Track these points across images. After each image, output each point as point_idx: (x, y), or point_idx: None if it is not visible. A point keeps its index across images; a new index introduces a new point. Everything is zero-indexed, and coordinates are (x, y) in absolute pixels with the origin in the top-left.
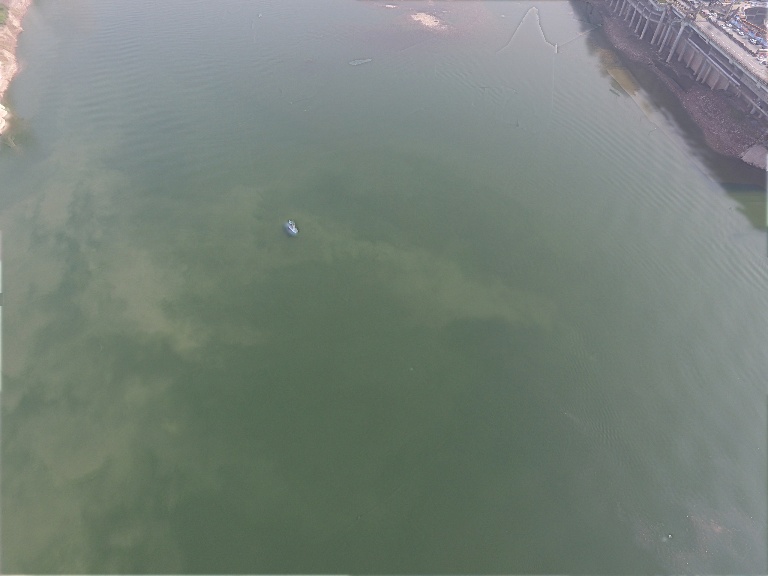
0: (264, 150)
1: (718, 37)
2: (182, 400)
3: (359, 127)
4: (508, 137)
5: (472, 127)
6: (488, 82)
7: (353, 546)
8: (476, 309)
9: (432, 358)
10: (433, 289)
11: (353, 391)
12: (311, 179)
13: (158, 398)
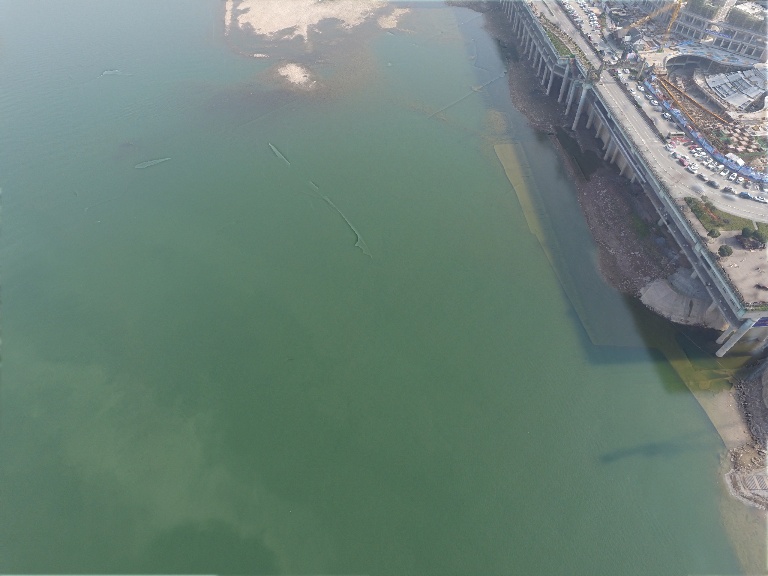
0: None
1: (623, 109)
2: None
3: (153, 249)
4: (338, 264)
5: (297, 246)
6: None
7: None
8: None
9: None
10: None
11: None
12: (22, 367)
13: None
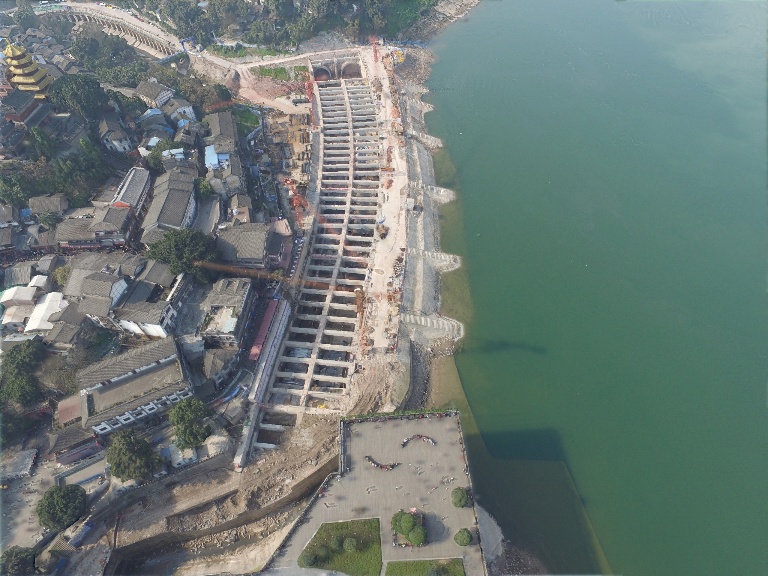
0: None
1: None
2: None
3: None
4: None
5: None
6: None
7: None
8: None
9: None
10: None
11: None
12: None
13: None
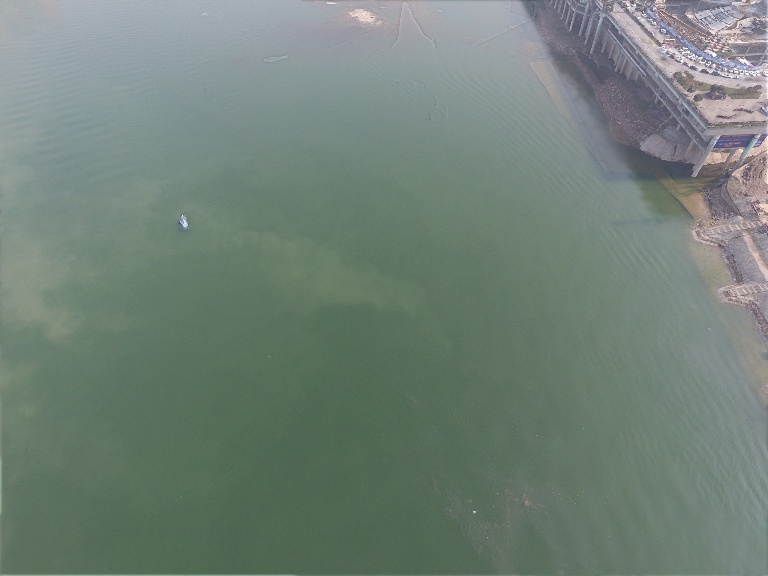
0: (172, 147)
1: (630, 28)
2: (45, 388)
3: (275, 123)
4: (417, 131)
5: (384, 121)
6: (396, 77)
7: (166, 523)
8: (344, 298)
9: (291, 346)
10: (308, 280)
11: (208, 378)
12: (209, 175)
13: (22, 387)
